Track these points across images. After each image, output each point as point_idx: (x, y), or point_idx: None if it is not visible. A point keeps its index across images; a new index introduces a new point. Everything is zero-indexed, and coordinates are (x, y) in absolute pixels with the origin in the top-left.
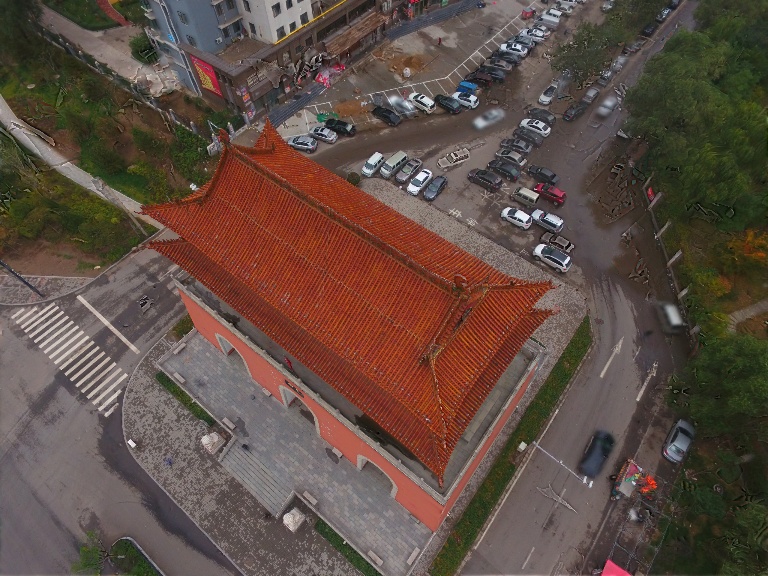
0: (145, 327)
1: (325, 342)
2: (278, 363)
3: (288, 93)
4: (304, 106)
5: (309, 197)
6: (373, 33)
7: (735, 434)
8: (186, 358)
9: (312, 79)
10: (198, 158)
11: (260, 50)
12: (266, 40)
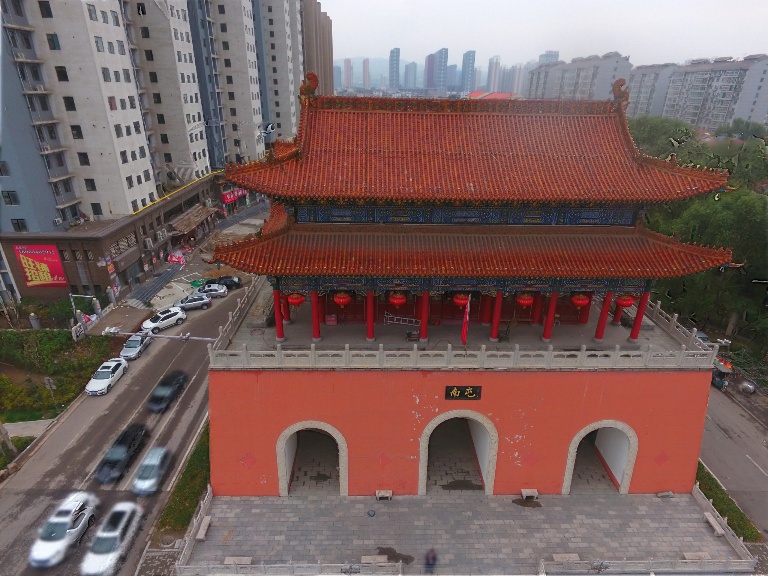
0: (97, 556)
1: (547, 196)
2: (441, 351)
3: (147, 271)
4: (170, 280)
5: (435, 100)
6: (202, 226)
7: (715, 305)
8: (223, 535)
9: (164, 261)
10: (58, 347)
11: (117, 221)
12: (118, 215)
